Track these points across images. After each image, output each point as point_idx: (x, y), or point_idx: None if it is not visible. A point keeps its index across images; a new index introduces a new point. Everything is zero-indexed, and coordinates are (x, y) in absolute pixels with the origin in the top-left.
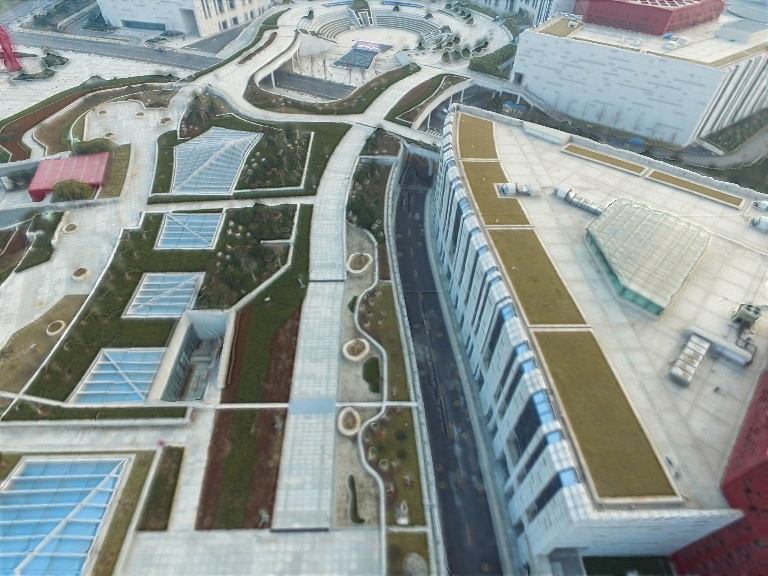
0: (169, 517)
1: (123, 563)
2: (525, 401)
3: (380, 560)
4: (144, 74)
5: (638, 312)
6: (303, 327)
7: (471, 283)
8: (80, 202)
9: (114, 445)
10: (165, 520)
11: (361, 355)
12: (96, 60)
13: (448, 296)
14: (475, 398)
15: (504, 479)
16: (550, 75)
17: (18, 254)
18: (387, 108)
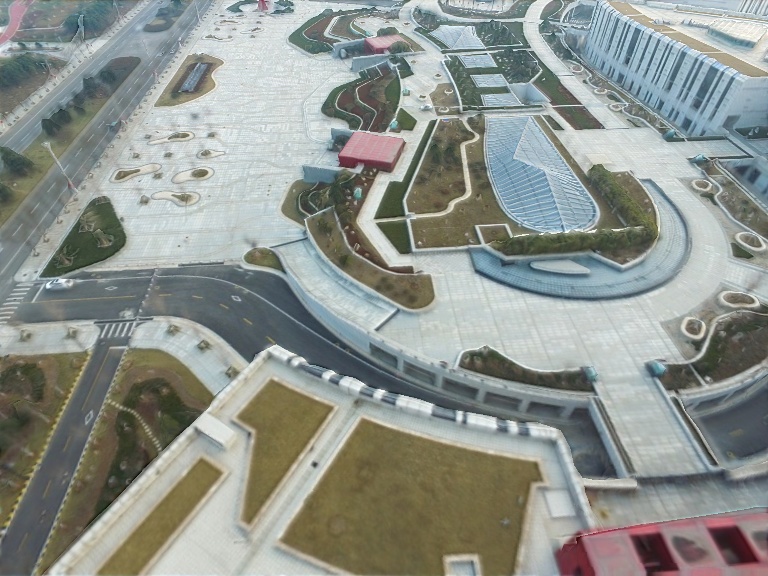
0: None
1: None
2: (706, 72)
3: (656, 132)
4: (351, 9)
5: (743, 49)
6: (568, 88)
7: (652, 60)
8: (406, 53)
9: None
10: (562, 128)
11: (605, 92)
12: (310, 3)
13: None
14: (658, 114)
15: (686, 130)
16: None
17: None
18: (538, 14)
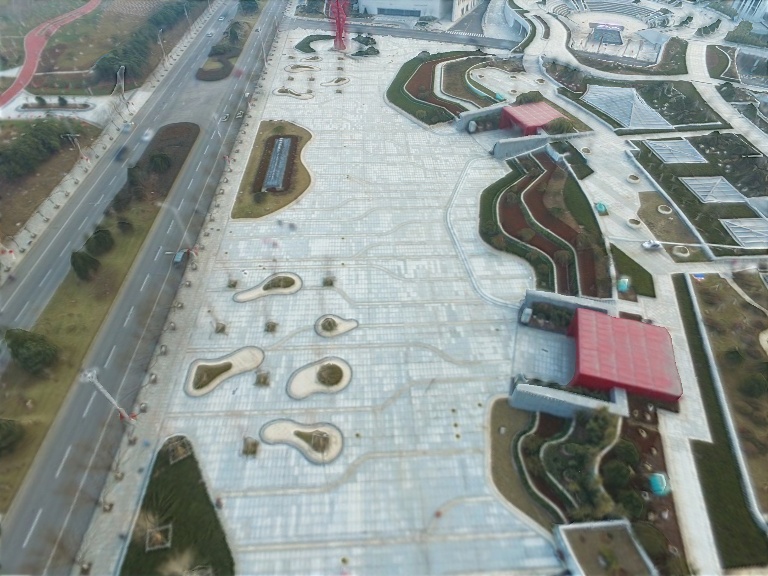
0: None
1: None
2: None
3: None
4: (448, 50)
5: None
6: None
7: None
8: (569, 135)
9: None
10: None
11: None
12: (395, 40)
13: None
14: None
15: None
16: None
17: (559, 170)
18: (703, 70)
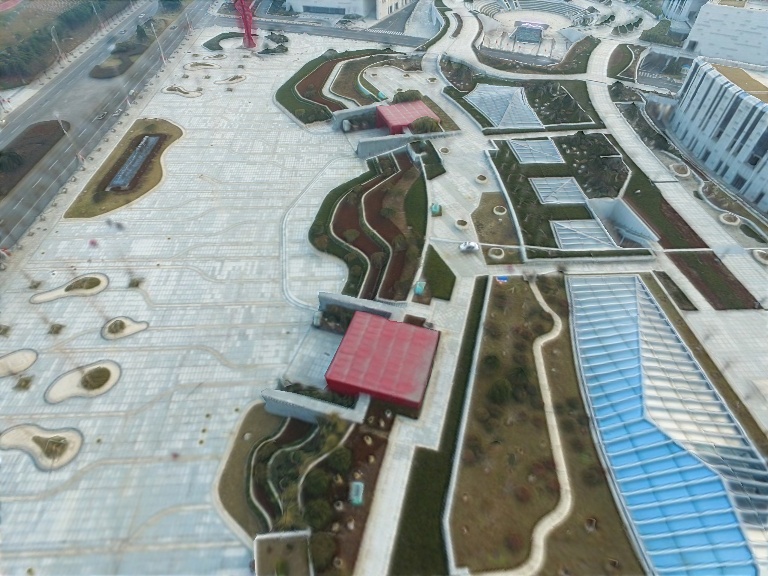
0: (693, 304)
1: (690, 324)
2: None
3: None
4: (360, 49)
5: None
6: (676, 208)
7: None
8: (434, 134)
9: (616, 271)
10: (692, 306)
11: (738, 222)
12: (310, 38)
13: (742, 197)
14: None
15: None
16: (726, 41)
17: (413, 170)
18: (603, 69)
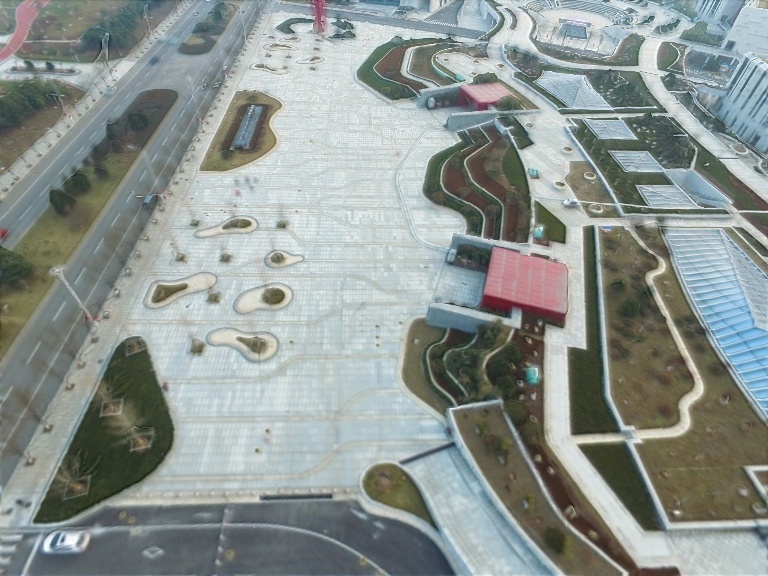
0: None
1: None
2: None
3: None
4: (421, 37)
5: None
6: (742, 179)
7: None
8: (517, 111)
9: None
10: None
11: None
12: (372, 26)
13: None
14: None
15: None
16: (762, 42)
17: (503, 141)
18: (653, 62)
